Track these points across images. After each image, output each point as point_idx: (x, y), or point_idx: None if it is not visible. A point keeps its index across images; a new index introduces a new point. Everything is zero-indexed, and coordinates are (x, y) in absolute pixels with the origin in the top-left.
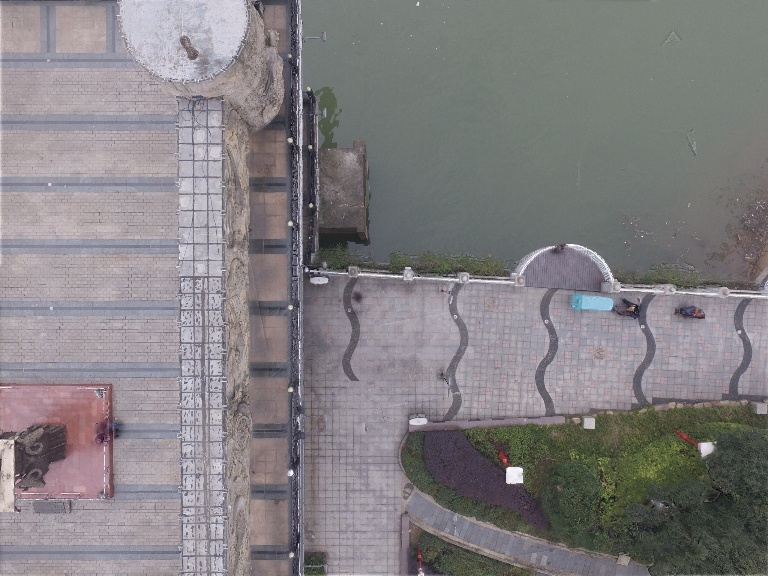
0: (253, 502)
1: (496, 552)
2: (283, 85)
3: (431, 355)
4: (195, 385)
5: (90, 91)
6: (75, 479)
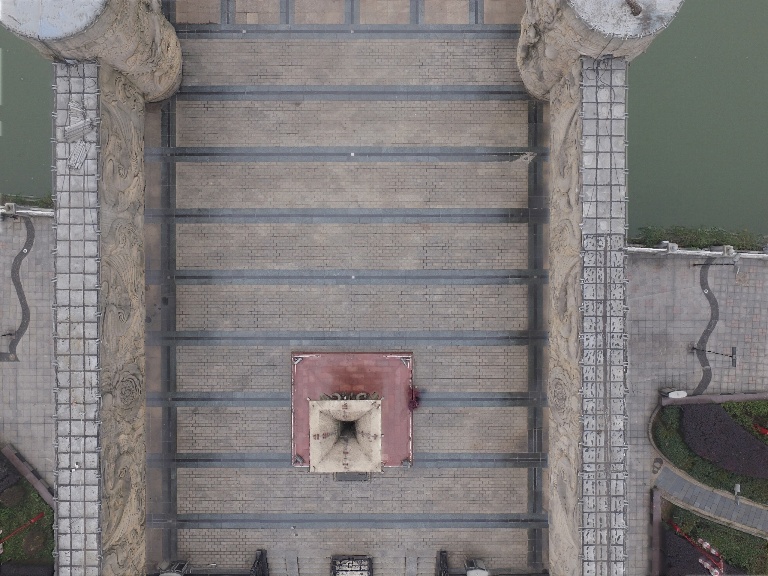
0: None
1: (748, 526)
2: None
3: (681, 329)
4: (597, 342)
5: (393, 62)
6: None
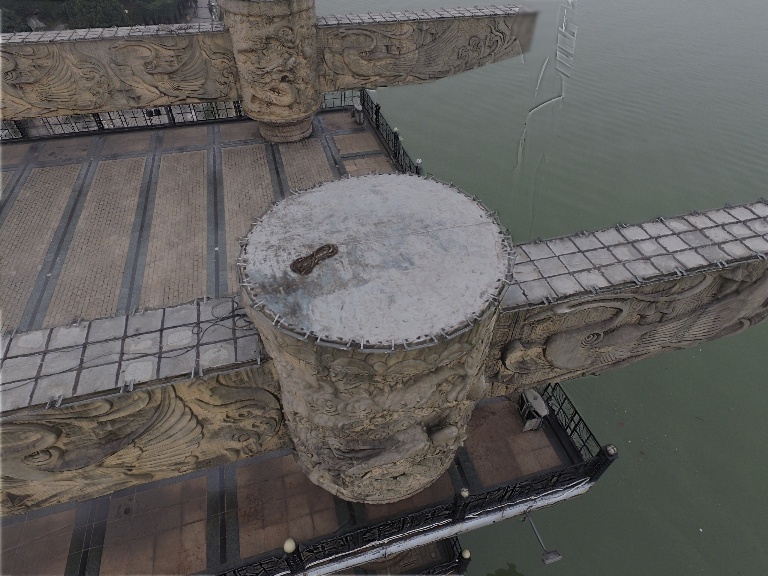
0: None
1: None
2: (404, 495)
3: None
4: None
5: None
6: None
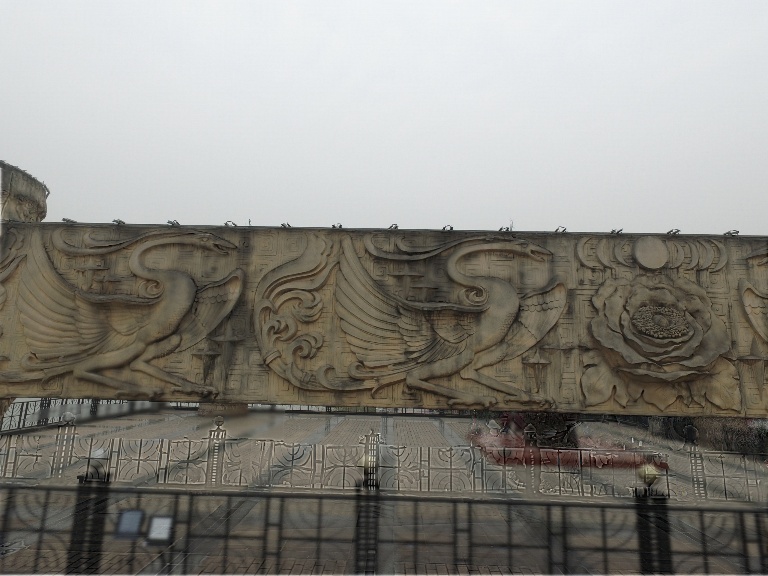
0: None
1: None
2: None
3: None
4: None
5: None
6: None
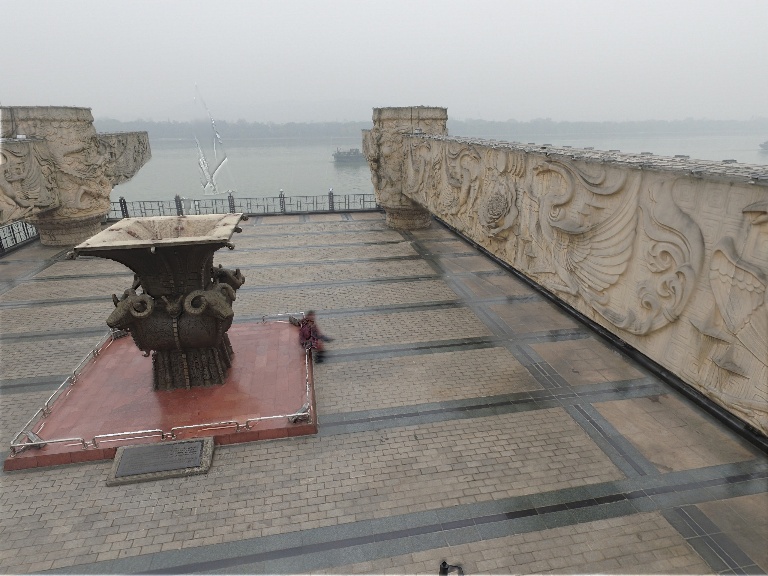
0: (611, 404)
1: None
2: None
3: None
4: None
5: None
6: (238, 406)
